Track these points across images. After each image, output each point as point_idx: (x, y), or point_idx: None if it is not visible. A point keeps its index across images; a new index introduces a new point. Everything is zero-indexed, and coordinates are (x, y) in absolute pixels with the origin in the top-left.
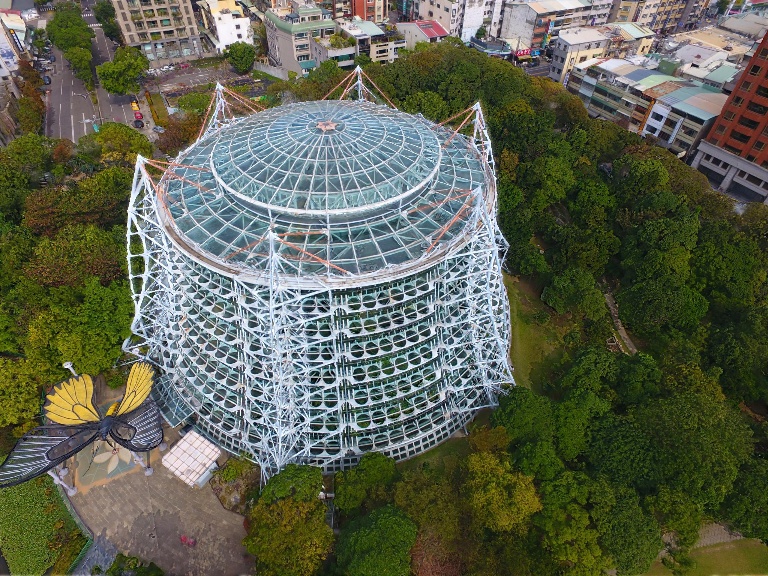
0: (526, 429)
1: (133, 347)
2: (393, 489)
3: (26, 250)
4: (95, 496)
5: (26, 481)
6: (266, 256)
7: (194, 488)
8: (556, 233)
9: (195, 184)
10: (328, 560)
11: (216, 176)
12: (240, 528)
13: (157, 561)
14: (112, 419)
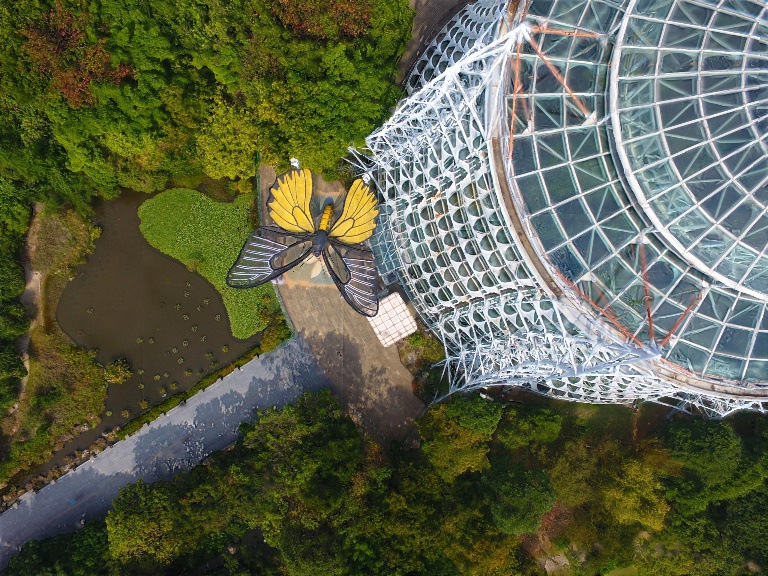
0: (699, 469)
1: (358, 147)
2: (554, 461)
3: None
4: (299, 294)
5: None
6: (607, 289)
7: None
8: None
9: (571, 93)
10: None
11: (613, 103)
12: (409, 384)
13: (340, 376)
14: (326, 237)
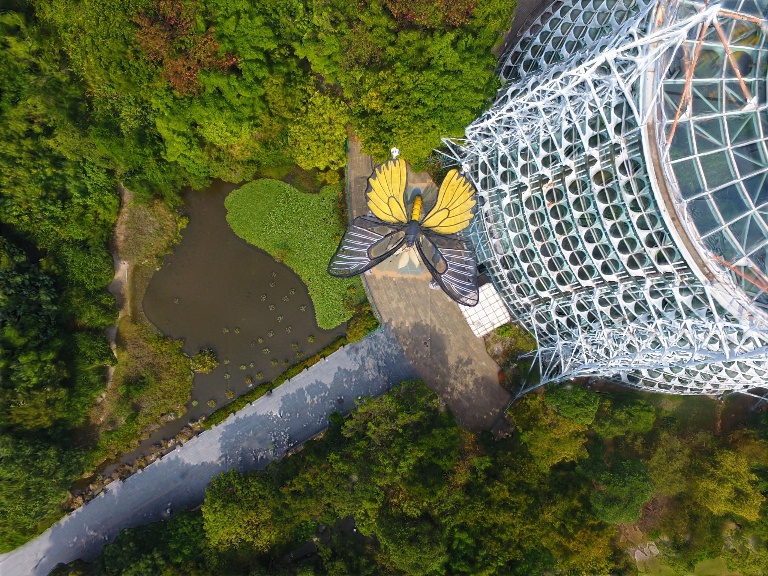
0: None
1: (451, 138)
2: (651, 451)
3: None
4: (386, 285)
5: None
6: (762, 274)
7: None
8: None
9: None
10: None
11: None
12: (494, 375)
13: (427, 367)
14: (419, 227)
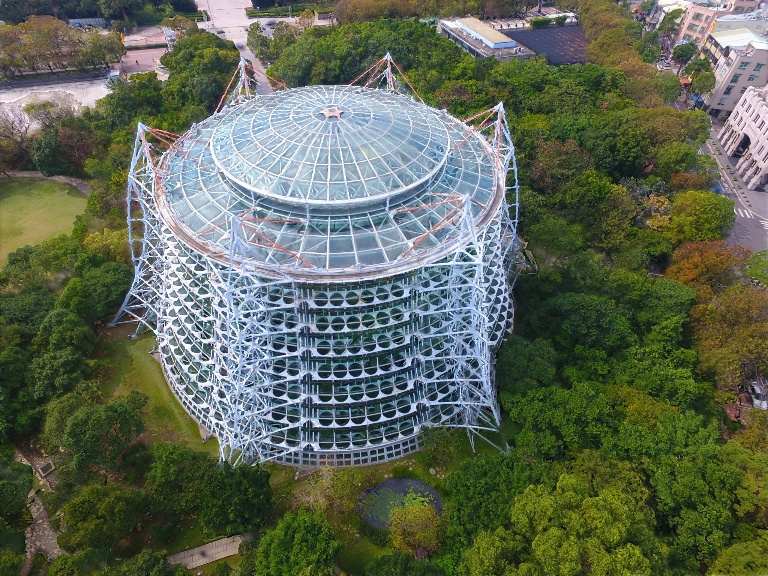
0: None
1: None
2: None
3: None
4: None
5: None
6: None
7: None
8: (160, 558)
9: None
10: None
11: None
12: None
13: None
14: None
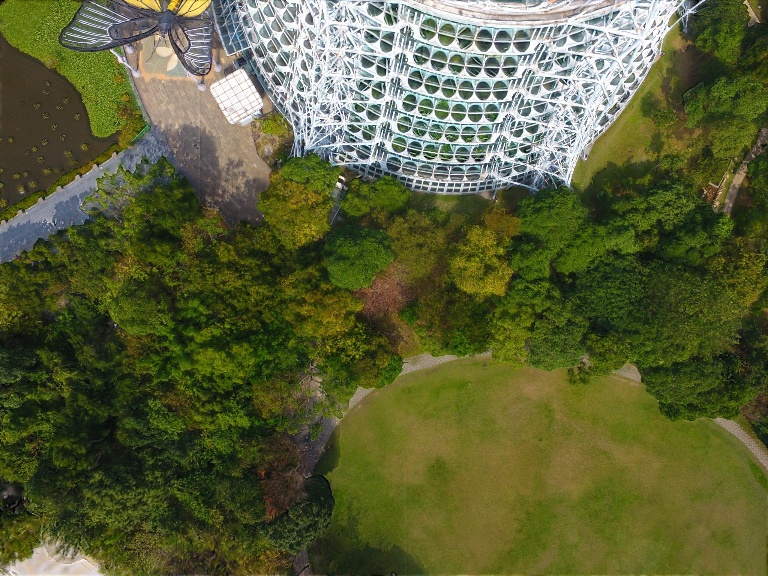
0: (541, 231)
1: None
2: (391, 220)
3: None
4: (155, 87)
5: (92, 50)
6: None
7: (237, 123)
8: None
9: None
10: (319, 241)
11: None
12: (266, 176)
13: (197, 169)
14: (172, 16)
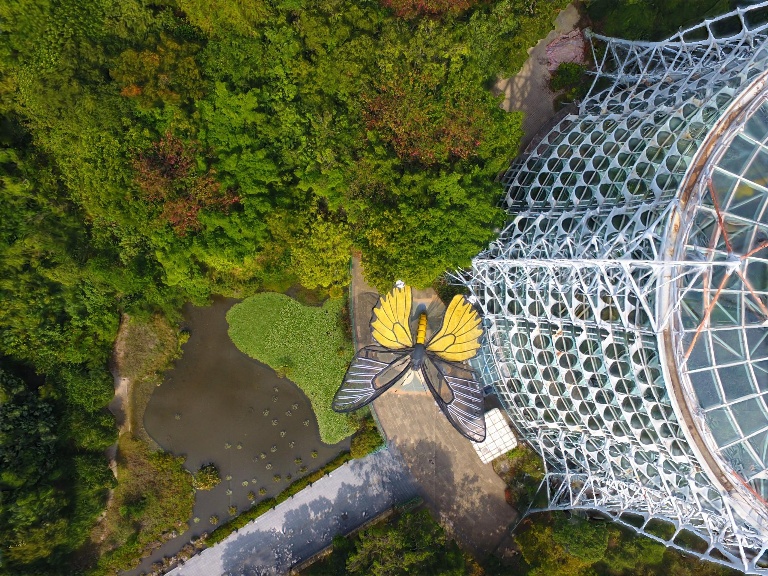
0: None
1: None
2: None
3: (367, 51)
4: (391, 402)
5: None
6: None
7: None
8: None
9: None
10: None
11: None
12: (501, 492)
13: (432, 484)
14: (425, 351)
